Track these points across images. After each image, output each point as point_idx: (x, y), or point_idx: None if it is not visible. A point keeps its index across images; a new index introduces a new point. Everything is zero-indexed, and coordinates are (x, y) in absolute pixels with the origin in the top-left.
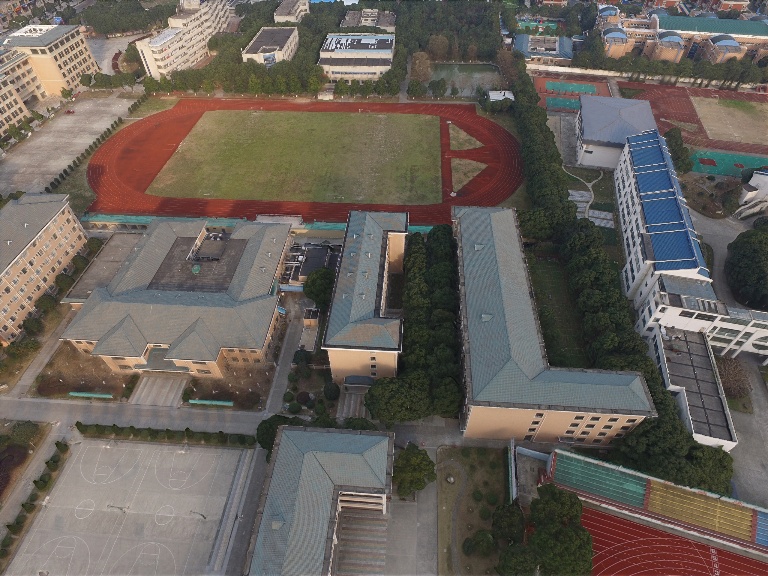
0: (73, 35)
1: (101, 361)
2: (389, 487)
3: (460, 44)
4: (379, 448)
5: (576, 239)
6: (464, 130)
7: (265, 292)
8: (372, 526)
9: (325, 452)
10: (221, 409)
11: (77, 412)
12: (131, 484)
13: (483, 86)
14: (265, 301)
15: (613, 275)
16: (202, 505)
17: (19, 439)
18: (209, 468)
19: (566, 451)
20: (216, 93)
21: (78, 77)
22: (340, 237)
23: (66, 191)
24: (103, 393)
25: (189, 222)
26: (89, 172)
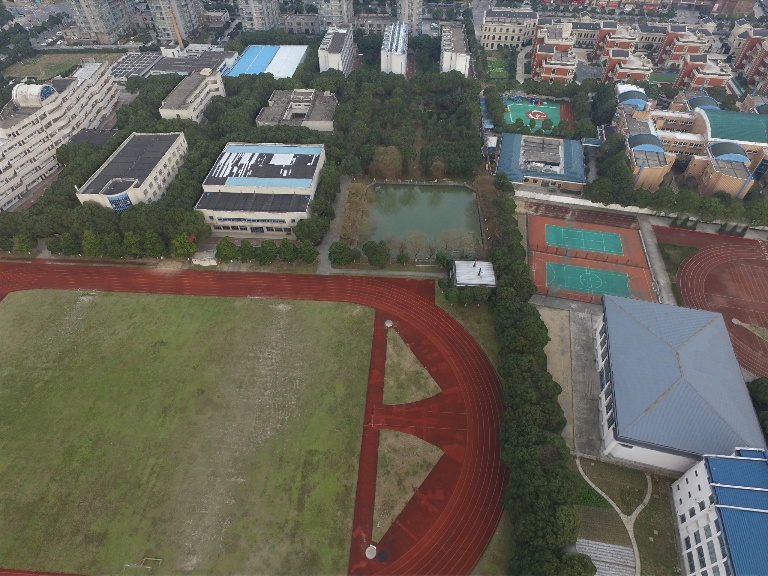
0: None
1: None
2: None
3: (422, 153)
4: None
5: None
6: (411, 347)
7: None
8: None
9: None
10: None
11: None
12: None
13: (447, 253)
14: None
15: None
16: None
17: None
18: None
19: None
20: (43, 248)
21: None
22: None
23: None
24: None
25: None
26: None
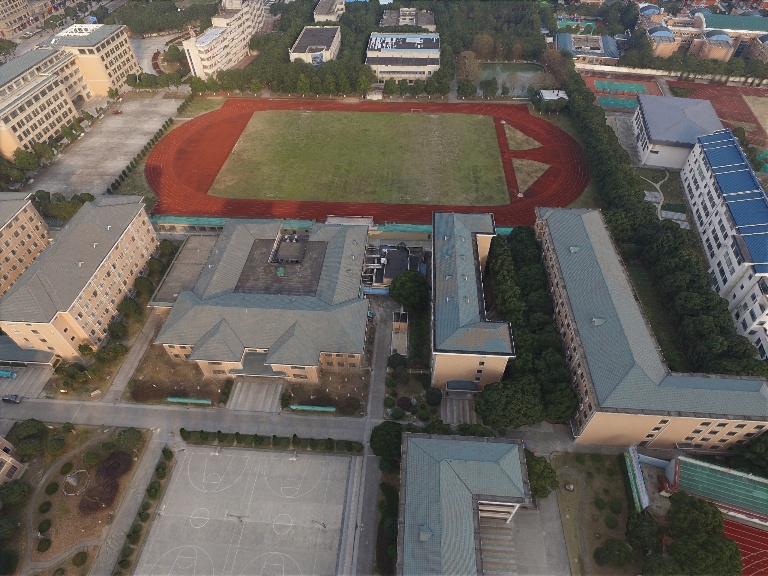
0: (118, 35)
1: (191, 366)
2: (529, 496)
3: (503, 43)
4: (511, 456)
5: (664, 241)
6: (520, 130)
7: (355, 295)
8: (497, 535)
9: (459, 460)
10: (322, 415)
11: (175, 418)
12: (243, 492)
13: (535, 85)
14: (358, 304)
15: (709, 277)
16: (319, 514)
17: (125, 446)
18: (320, 475)
19: (690, 458)
20: (262, 93)
21: (122, 77)
22: (413, 239)
23: (127, 192)
24: (199, 398)
25: (266, 224)
26: (147, 173)
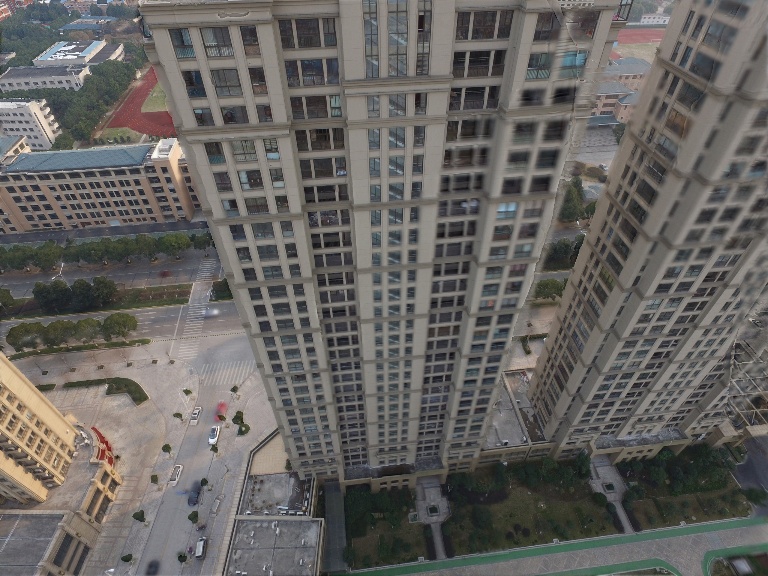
0: None
1: None
2: None
3: None
4: None
5: None
6: None
7: None
8: None
9: None
10: None
11: None
12: None
13: None
14: None
15: None
16: None
17: None
18: None
19: None
20: None
21: None
22: None
23: None
24: None
25: None
26: None
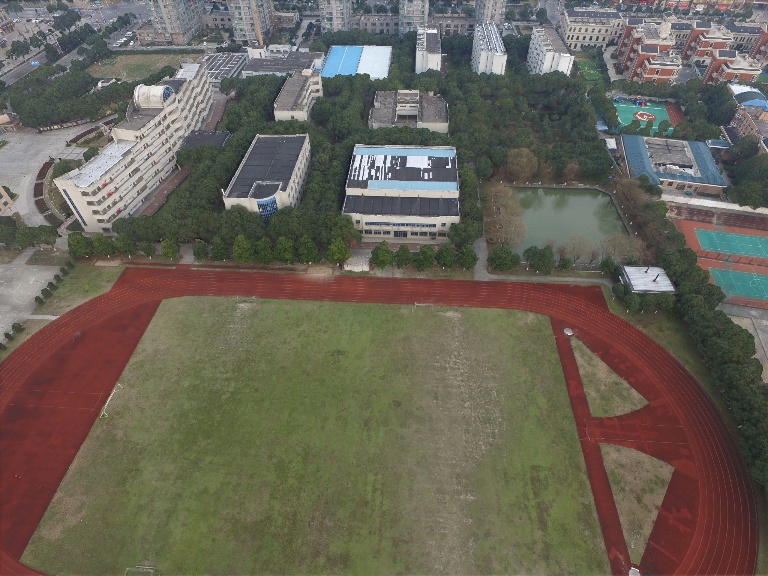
0: None
1: None
2: None
3: (548, 155)
4: None
5: None
6: (600, 356)
7: None
8: None
9: None
10: None
11: None
12: None
13: (614, 258)
14: None
15: None
16: None
17: None
18: None
19: None
20: (183, 253)
21: None
22: None
23: None
24: None
25: None
26: None
